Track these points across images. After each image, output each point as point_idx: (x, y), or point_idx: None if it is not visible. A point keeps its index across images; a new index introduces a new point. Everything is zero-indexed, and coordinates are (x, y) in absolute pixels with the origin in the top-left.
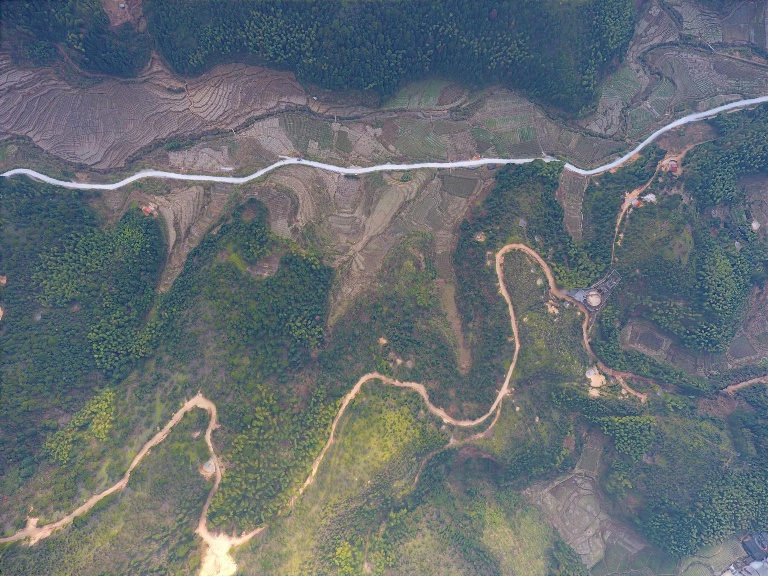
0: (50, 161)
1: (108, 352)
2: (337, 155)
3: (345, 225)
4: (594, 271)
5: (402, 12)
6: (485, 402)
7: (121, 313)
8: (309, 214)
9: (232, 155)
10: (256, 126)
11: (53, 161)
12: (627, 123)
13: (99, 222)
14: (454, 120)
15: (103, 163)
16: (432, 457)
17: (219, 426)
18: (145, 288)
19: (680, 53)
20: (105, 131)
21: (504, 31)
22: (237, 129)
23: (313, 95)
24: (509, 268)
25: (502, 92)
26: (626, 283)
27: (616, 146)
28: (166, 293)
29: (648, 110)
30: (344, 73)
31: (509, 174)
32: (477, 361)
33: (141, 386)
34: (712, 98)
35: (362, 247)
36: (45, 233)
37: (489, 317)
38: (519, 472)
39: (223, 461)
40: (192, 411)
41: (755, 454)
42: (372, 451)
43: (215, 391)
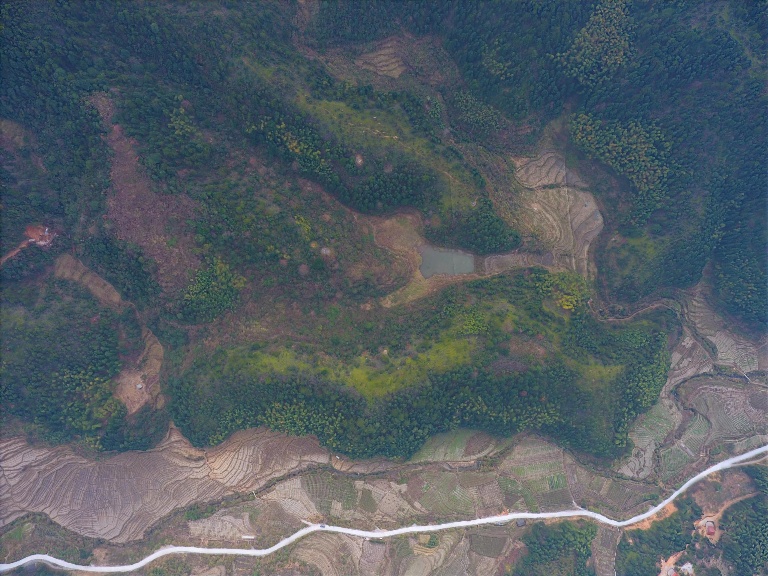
0: (67, 537)
1: None
2: (361, 515)
3: None
4: None
5: (429, 400)
6: None
7: None
8: None
9: (253, 522)
10: (277, 488)
11: (70, 537)
12: (660, 464)
13: None
14: (481, 471)
15: (121, 536)
16: None
17: None
18: None
19: (714, 386)
20: (123, 503)
21: (534, 403)
22: (258, 491)
23: (336, 455)
24: None
25: (530, 438)
26: None
27: (649, 490)
28: None
29: (682, 450)
30: (369, 452)
31: (540, 544)
32: None
33: None
34: (749, 439)
35: None
36: None
37: None
38: None
39: None
40: None
41: None
42: None
43: None
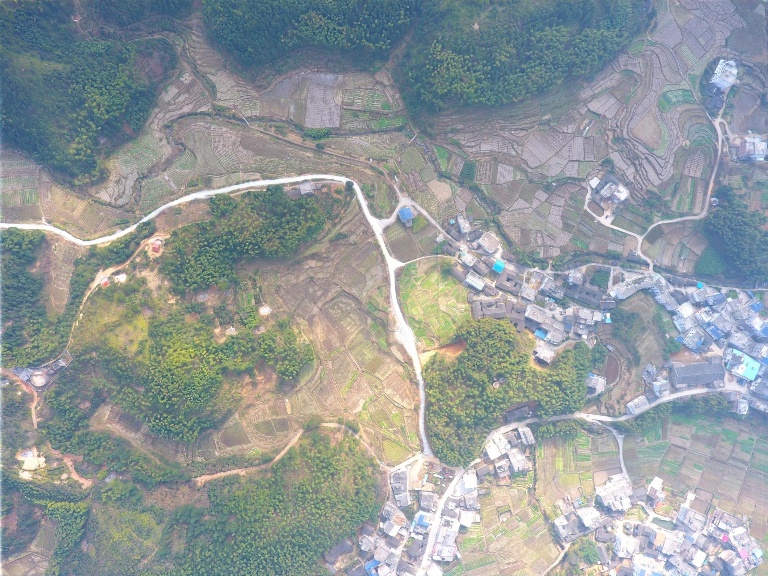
0: None
1: None
2: None
3: None
4: (42, 350)
5: None
6: None
7: None
8: None
9: None
10: None
11: None
12: (141, 194)
13: None
14: None
15: None
16: None
17: None
18: None
19: (209, 124)
20: None
21: None
22: None
23: None
24: None
25: (7, 152)
26: (80, 365)
27: (125, 217)
28: None
29: (164, 182)
30: None
31: None
32: None
33: None
34: (229, 175)
35: None
36: None
37: None
38: None
39: None
40: None
41: (182, 553)
42: None
43: None
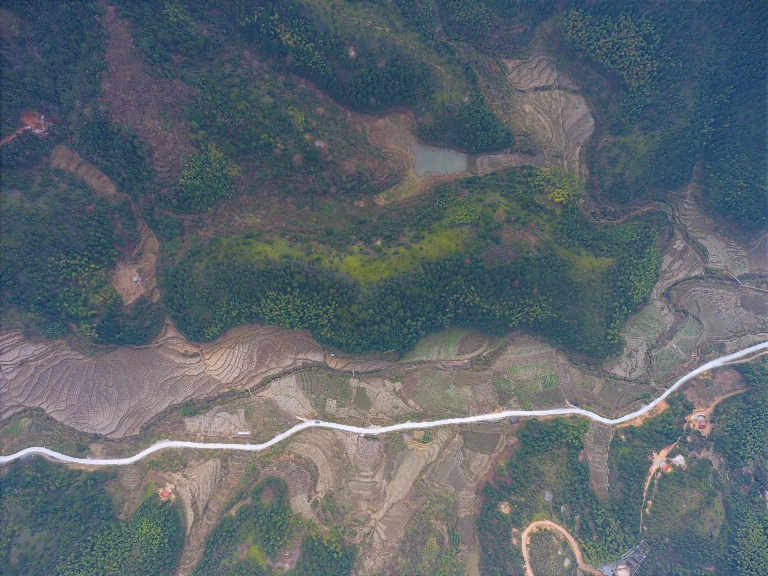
0: (64, 432)
1: None
2: (356, 413)
3: (365, 490)
4: (622, 543)
5: (422, 289)
6: None
7: None
8: (329, 483)
9: (249, 419)
10: (273, 386)
11: (67, 432)
12: (652, 365)
13: None
14: (475, 370)
15: (118, 432)
16: None
17: None
18: None
19: (706, 288)
20: (119, 399)
21: (526, 295)
22: (253, 389)
23: (330, 353)
24: (536, 552)
25: (523, 338)
26: (655, 553)
27: (641, 390)
28: None
29: (674, 351)
30: (363, 344)
31: (533, 437)
32: None
33: None
34: (740, 339)
35: (383, 515)
36: (62, 541)
37: None
38: None
39: None
40: None
41: None
42: None
43: None
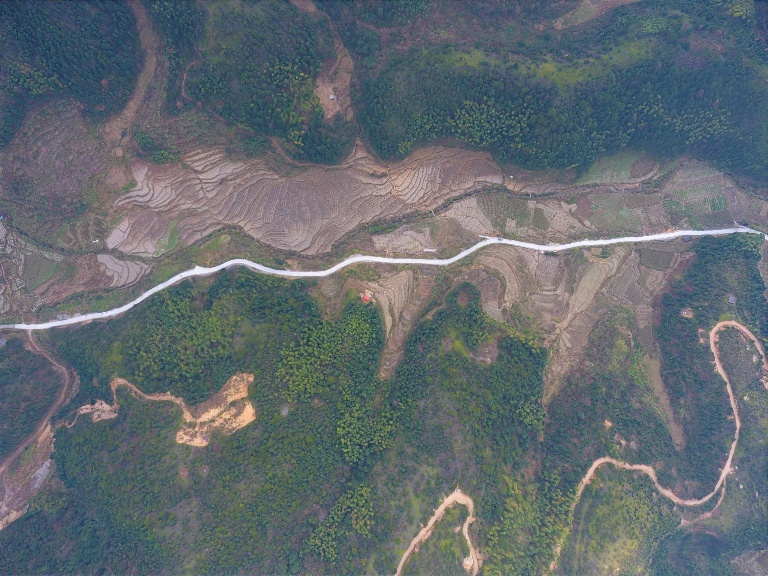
0: (261, 249)
1: (353, 445)
2: (534, 232)
3: (548, 303)
4: None
5: (612, 96)
6: (709, 481)
7: (359, 405)
8: (515, 294)
9: (434, 237)
10: (455, 207)
11: (264, 249)
12: None
13: (321, 311)
14: (646, 193)
15: (311, 249)
16: (664, 538)
17: (474, 519)
18: (371, 376)
19: None
20: (312, 218)
21: (707, 108)
22: (436, 210)
23: (510, 174)
24: (726, 347)
25: (692, 163)
26: None
27: None
28: (392, 380)
29: None
30: (550, 156)
31: (711, 248)
32: (694, 438)
33: (391, 479)
34: None
35: (567, 325)
36: (283, 329)
37: (704, 394)
38: (736, 545)
39: (483, 554)
40: (454, 508)
41: None
42: (621, 540)
43: (472, 486)
